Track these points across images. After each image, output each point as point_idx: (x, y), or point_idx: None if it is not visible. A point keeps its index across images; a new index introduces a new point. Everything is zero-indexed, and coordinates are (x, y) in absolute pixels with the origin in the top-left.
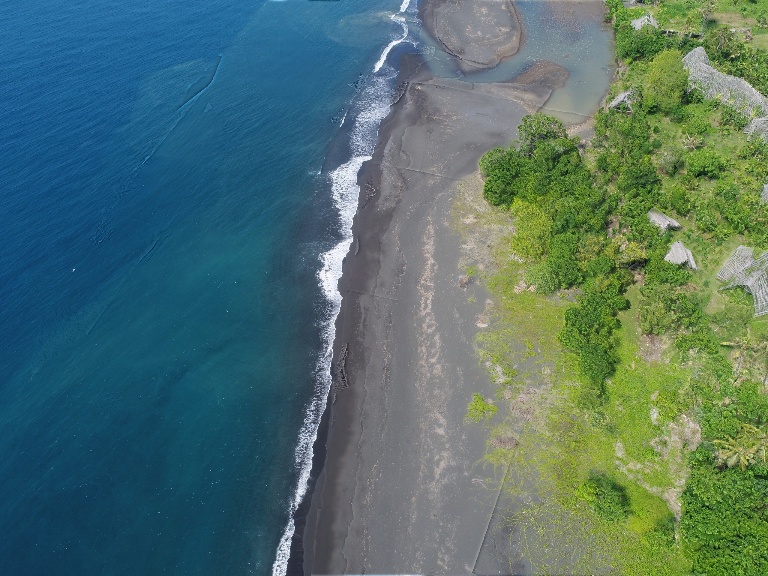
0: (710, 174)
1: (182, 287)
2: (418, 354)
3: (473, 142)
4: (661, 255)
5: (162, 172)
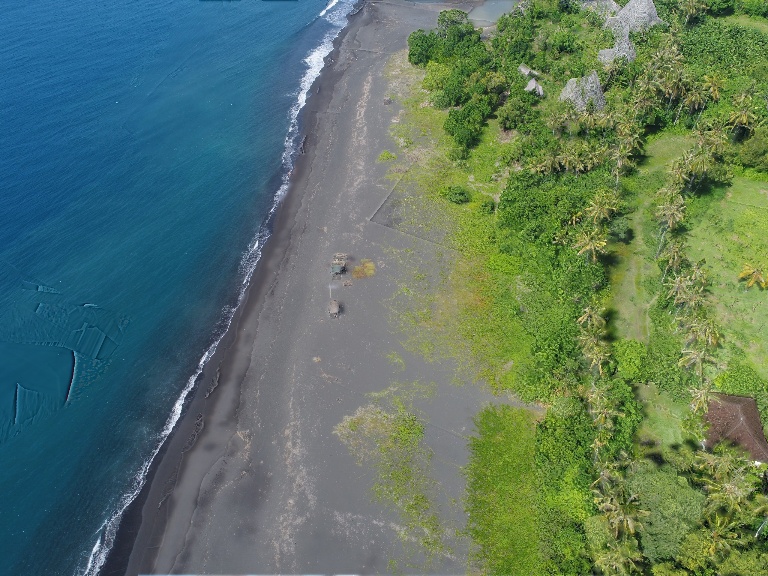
0: (568, 49)
1: (195, 99)
2: (351, 136)
3: (408, 35)
4: (520, 86)
5: (180, 44)
